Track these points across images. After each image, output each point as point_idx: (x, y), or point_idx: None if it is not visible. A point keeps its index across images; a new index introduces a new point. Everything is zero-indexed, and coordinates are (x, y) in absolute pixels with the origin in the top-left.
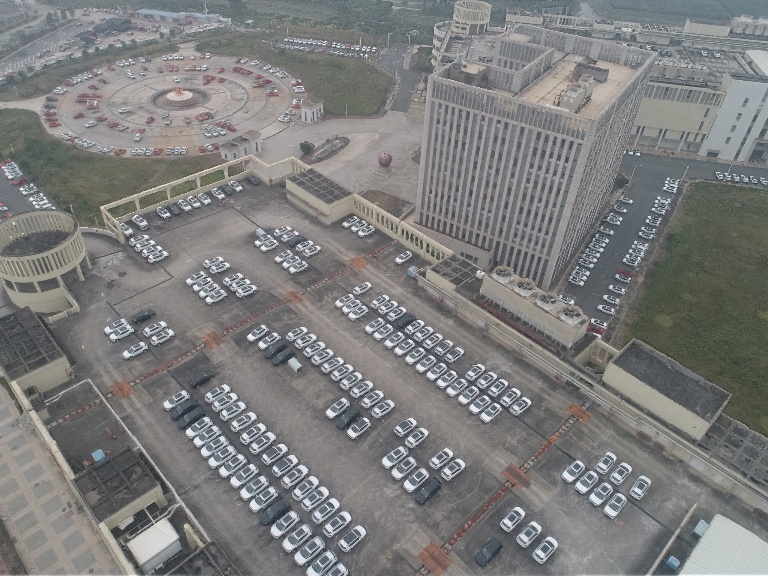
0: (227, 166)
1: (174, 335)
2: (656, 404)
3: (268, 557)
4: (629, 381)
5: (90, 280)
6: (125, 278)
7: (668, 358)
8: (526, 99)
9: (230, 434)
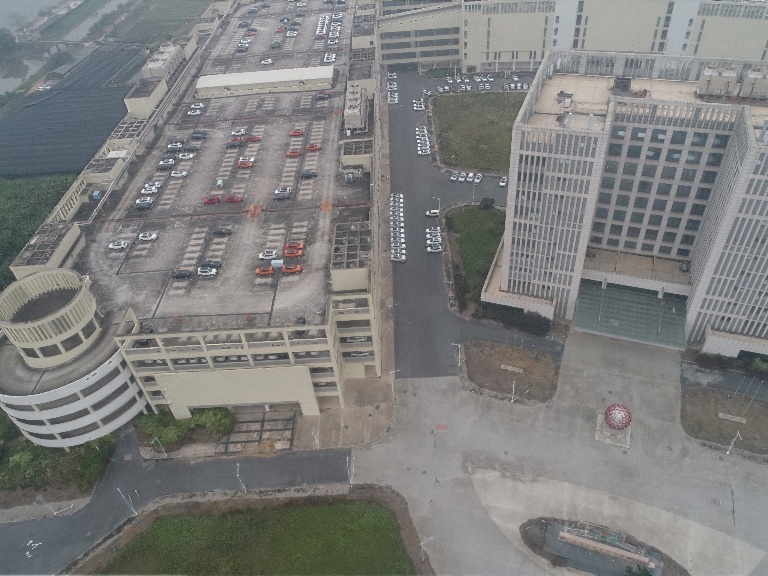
0: None
1: None
2: None
3: None
4: None
5: None
6: None
7: None
8: (754, 122)
9: None
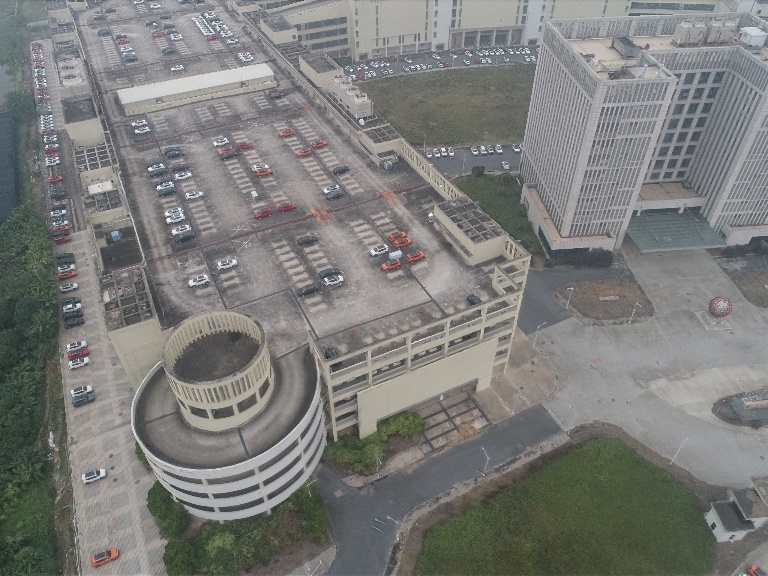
0: None
1: None
2: None
3: None
4: None
5: None
6: None
7: None
8: None
9: None
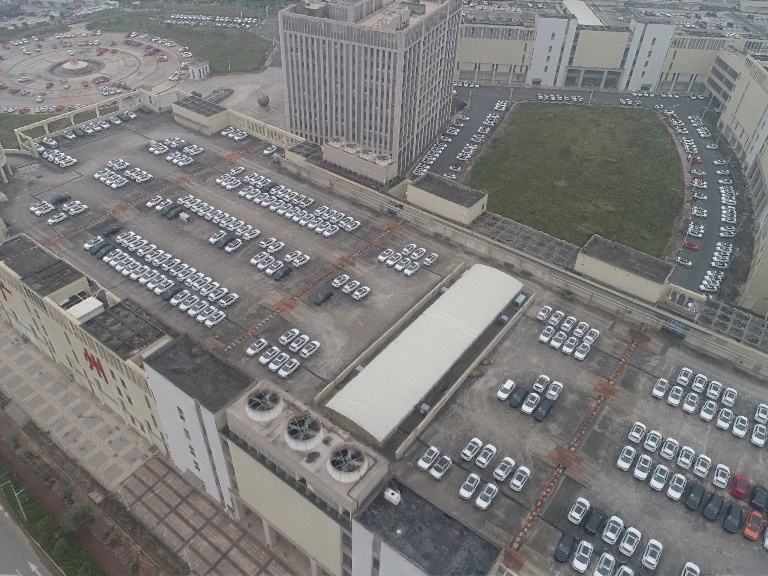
0: (121, 98)
1: (88, 208)
2: (439, 206)
3: (169, 315)
4: (421, 195)
5: (13, 182)
6: (42, 179)
7: None
8: None
9: (137, 258)
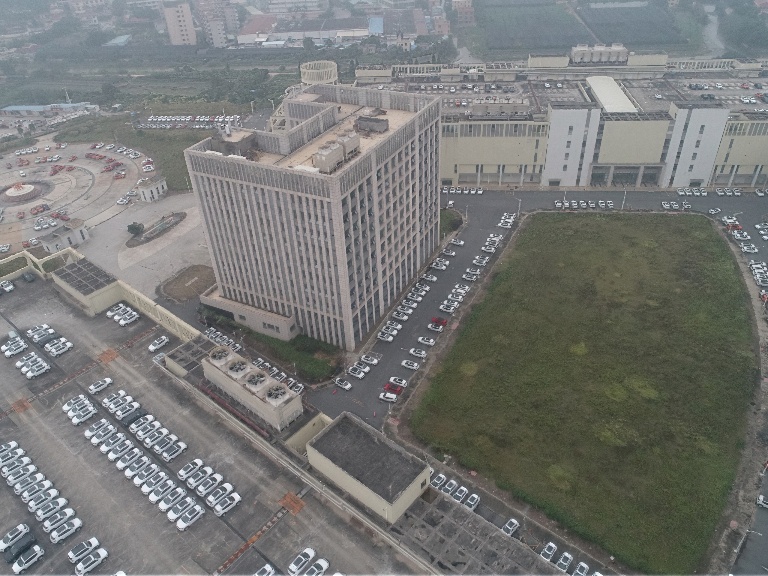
0: None
1: None
2: (351, 487)
3: None
4: (325, 463)
5: None
6: None
7: (373, 430)
8: (293, 161)
9: None
